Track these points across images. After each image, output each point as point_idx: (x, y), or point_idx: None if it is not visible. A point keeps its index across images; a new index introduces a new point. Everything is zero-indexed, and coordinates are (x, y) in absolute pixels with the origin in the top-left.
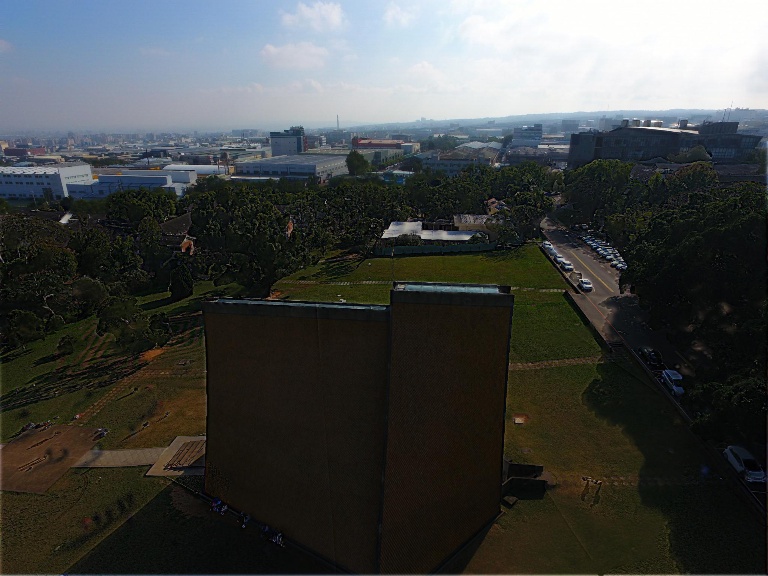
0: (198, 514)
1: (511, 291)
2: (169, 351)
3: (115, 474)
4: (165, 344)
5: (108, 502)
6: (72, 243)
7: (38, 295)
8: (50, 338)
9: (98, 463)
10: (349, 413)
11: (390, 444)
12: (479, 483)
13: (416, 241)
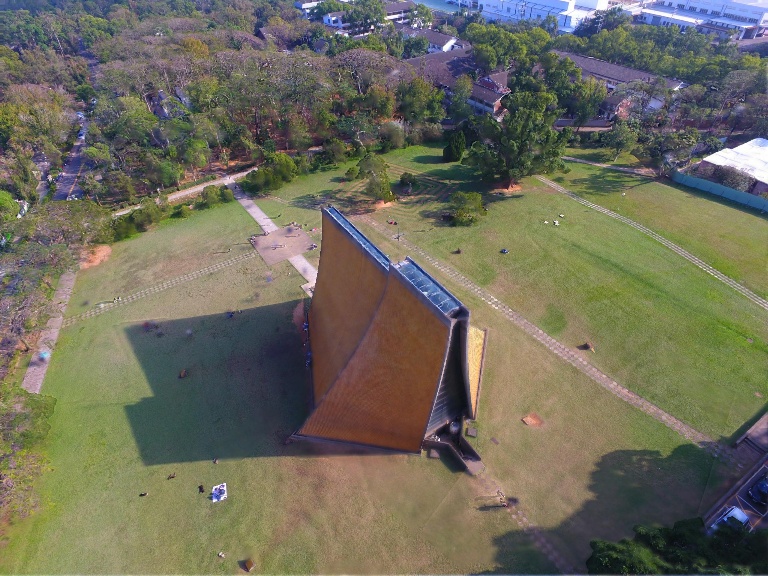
0: (297, 323)
1: (757, 308)
2: (393, 207)
3: (295, 276)
4: (396, 200)
5: (279, 289)
6: (399, 88)
7: (354, 130)
8: (353, 163)
9: (296, 264)
10: (358, 324)
11: (353, 359)
12: (402, 424)
13: (737, 182)
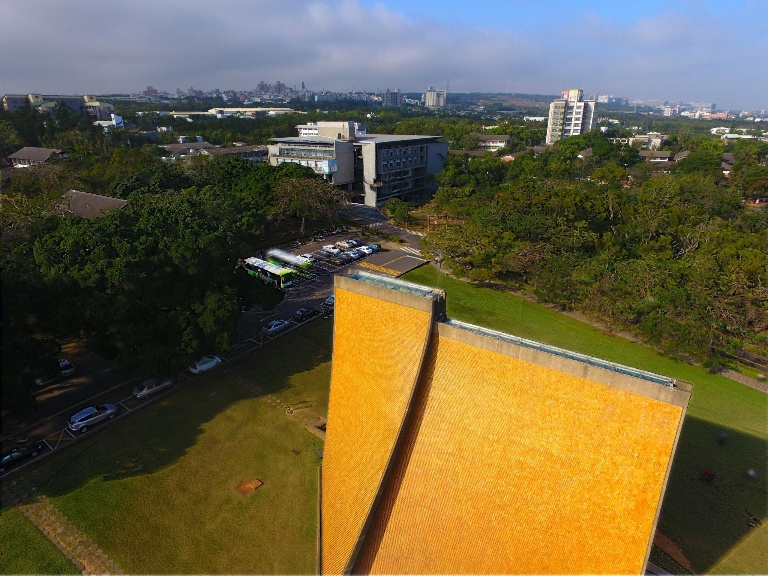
0: None
1: None
2: None
3: None
4: None
5: None
6: None
7: None
8: None
9: None
10: None
11: None
12: None
13: None
